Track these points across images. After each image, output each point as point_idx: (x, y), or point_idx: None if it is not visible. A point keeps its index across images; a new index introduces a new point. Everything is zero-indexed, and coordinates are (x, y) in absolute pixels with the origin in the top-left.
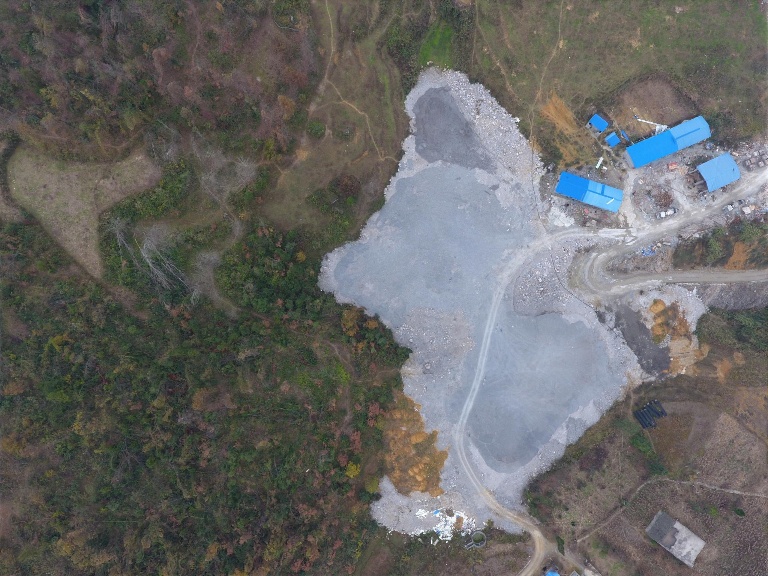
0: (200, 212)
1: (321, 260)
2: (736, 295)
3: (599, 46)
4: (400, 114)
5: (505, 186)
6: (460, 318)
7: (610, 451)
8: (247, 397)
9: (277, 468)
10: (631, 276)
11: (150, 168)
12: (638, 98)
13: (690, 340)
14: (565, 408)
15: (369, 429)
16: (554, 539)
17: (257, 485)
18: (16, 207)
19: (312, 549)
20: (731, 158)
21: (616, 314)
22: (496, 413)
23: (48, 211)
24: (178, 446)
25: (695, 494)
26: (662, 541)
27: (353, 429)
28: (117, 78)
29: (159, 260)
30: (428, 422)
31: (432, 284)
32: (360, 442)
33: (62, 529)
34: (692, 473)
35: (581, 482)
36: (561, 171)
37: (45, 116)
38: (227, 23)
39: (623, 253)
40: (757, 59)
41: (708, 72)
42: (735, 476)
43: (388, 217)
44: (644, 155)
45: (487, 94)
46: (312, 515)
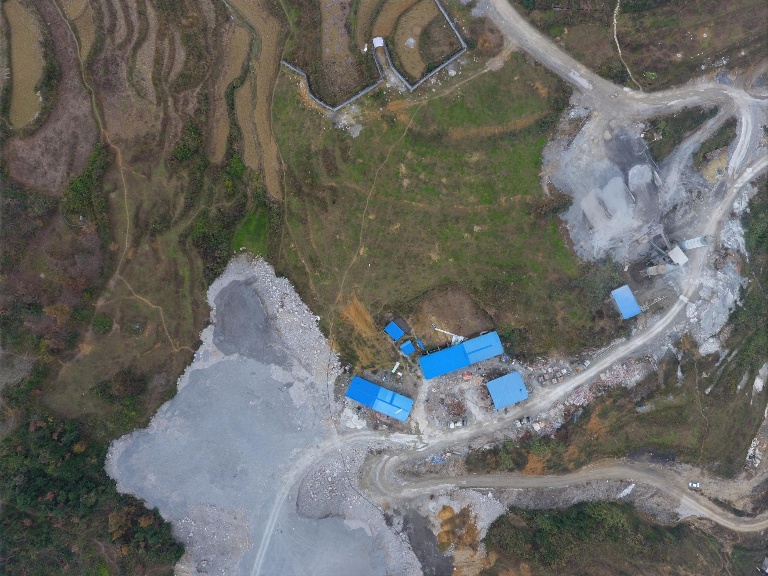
0: None
1: (108, 446)
2: (534, 499)
3: (399, 256)
4: (201, 304)
5: (299, 384)
6: (240, 517)
7: None
8: None
9: None
10: (423, 479)
11: None
12: (437, 307)
13: (475, 550)
14: None
15: None
16: None
17: None
18: None
19: None
20: (520, 377)
21: (404, 518)
22: None
23: None
24: None
25: None
26: None
27: None
28: None
29: None
30: None
31: (216, 480)
32: None
33: None
34: None
35: None
36: (357, 373)
37: None
38: (10, 222)
39: (414, 458)
40: (553, 281)
41: (506, 288)
42: None
43: (178, 408)
44: (435, 367)
45: (291, 289)
46: None
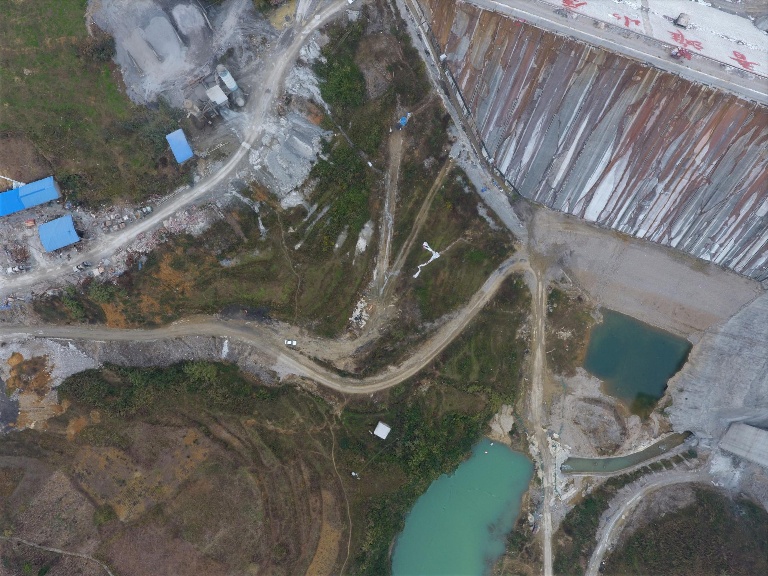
0: None
1: None
2: (123, 353)
3: None
4: None
5: None
6: None
7: None
8: None
9: None
10: None
11: None
12: None
13: (41, 395)
14: None
15: None
16: None
17: None
18: None
19: None
20: (71, 220)
21: None
22: None
23: None
24: None
25: (11, 550)
26: None
27: None
28: None
29: None
30: None
31: None
32: None
33: None
34: (9, 528)
35: None
36: None
37: None
38: None
39: None
40: (107, 125)
41: (64, 134)
42: (57, 534)
43: None
44: None
45: None
46: None
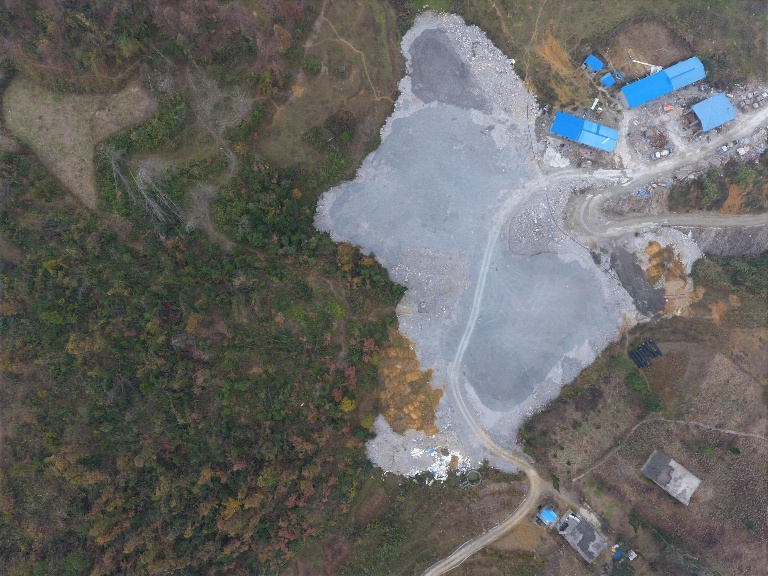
0: (196, 146)
1: (317, 200)
2: (731, 240)
3: None
4: (396, 55)
5: (501, 127)
6: (455, 257)
7: (605, 391)
8: (242, 328)
9: (271, 400)
10: (626, 218)
11: (146, 100)
12: (633, 39)
13: (685, 281)
14: (560, 346)
15: (364, 366)
16: (549, 478)
17: (251, 416)
18: (11, 137)
19: (306, 482)
20: (726, 98)
21: (611, 256)
22: (491, 352)
23: (44, 142)
24: (172, 374)
25: (690, 433)
26: (657, 479)
27: (348, 364)
28: (113, 8)
29: (154, 192)
30: (423, 360)
31: (428, 223)
32: (355, 378)
33: (55, 448)
34: (687, 412)
35: (576, 422)
36: (556, 112)
37: (41, 45)
38: None
39: (618, 194)
40: None
41: (703, 13)
42: (730, 416)
43: (384, 157)
44: (639, 95)
45: (483, 36)
46: (307, 450)
